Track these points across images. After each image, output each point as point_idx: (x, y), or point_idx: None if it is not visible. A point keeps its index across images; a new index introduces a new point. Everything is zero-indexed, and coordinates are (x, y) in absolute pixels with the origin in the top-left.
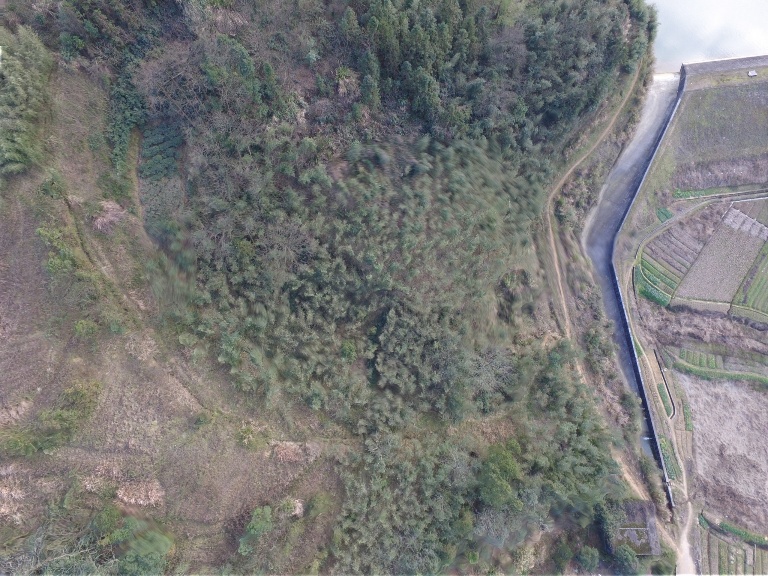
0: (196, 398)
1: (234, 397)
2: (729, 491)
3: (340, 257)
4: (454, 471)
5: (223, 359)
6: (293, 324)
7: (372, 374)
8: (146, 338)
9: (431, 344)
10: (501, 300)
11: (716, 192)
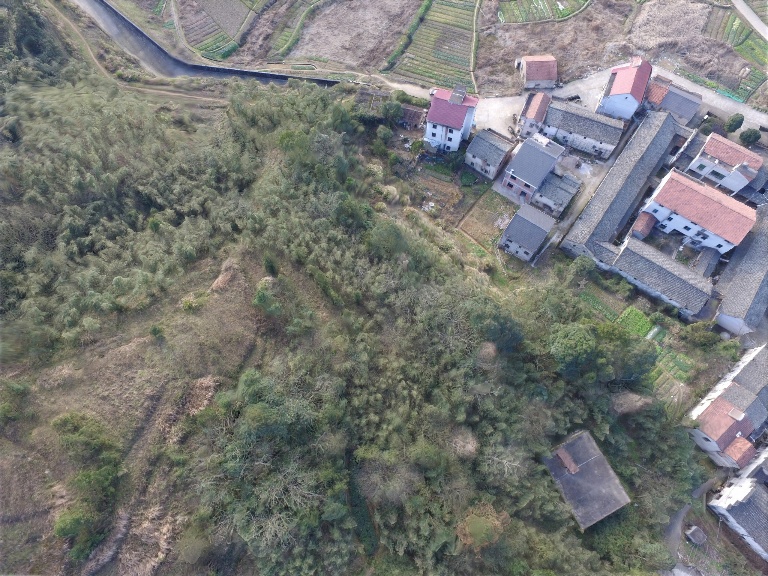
0: None
1: (152, 310)
2: (370, 52)
3: None
4: None
5: (106, 303)
6: None
7: None
8: (51, 373)
9: (184, 172)
10: None
11: None
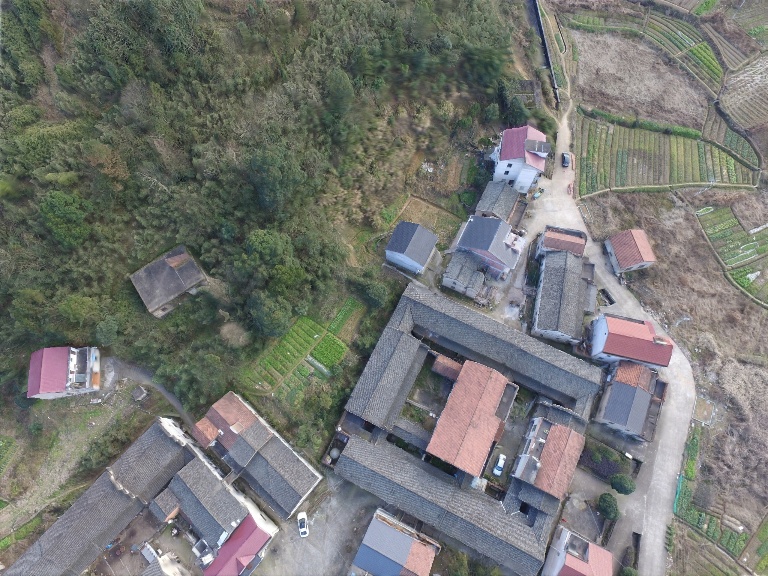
0: None
1: None
2: (600, 92)
3: None
4: (394, 20)
5: None
6: None
7: None
8: None
9: None
10: None
11: None
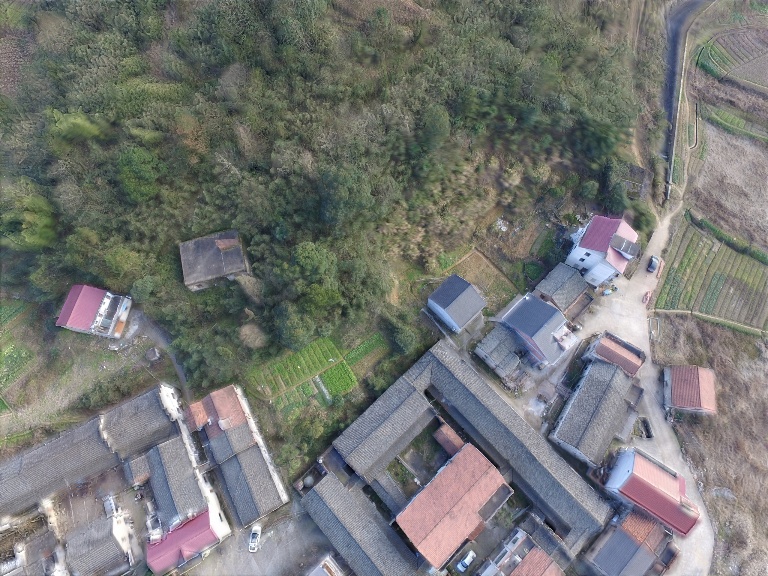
0: None
1: None
2: (718, 202)
3: None
4: (518, 68)
5: None
6: None
7: (482, 0)
8: None
9: None
10: (590, 8)
11: None
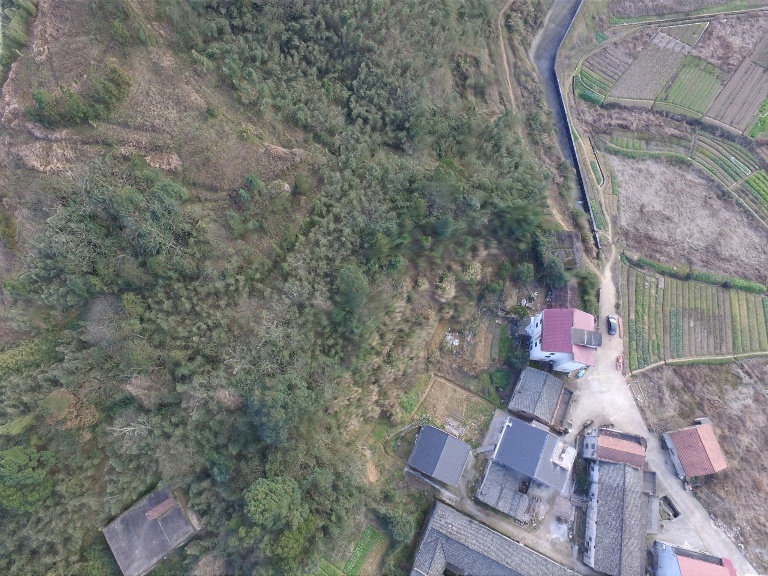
0: (206, 101)
1: (236, 106)
2: (646, 235)
3: (320, 16)
4: (412, 180)
5: (227, 70)
6: (283, 66)
7: (347, 114)
8: (166, 55)
9: (395, 94)
10: (456, 80)
11: (646, 19)
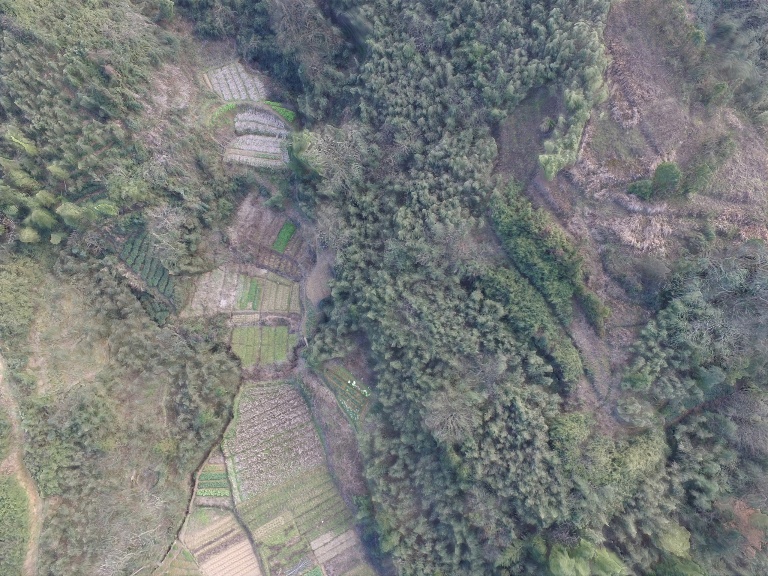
0: None
1: None
2: None
3: None
4: None
5: None
6: None
7: None
8: None
9: None
10: None
11: None
